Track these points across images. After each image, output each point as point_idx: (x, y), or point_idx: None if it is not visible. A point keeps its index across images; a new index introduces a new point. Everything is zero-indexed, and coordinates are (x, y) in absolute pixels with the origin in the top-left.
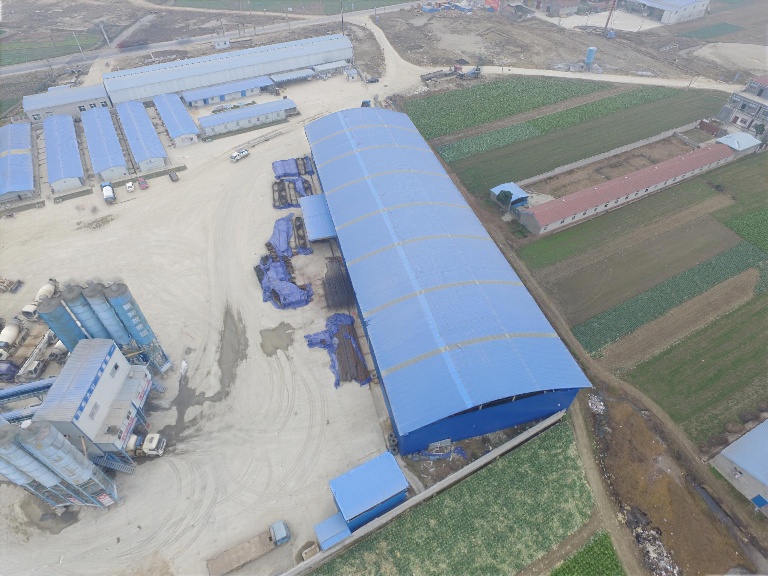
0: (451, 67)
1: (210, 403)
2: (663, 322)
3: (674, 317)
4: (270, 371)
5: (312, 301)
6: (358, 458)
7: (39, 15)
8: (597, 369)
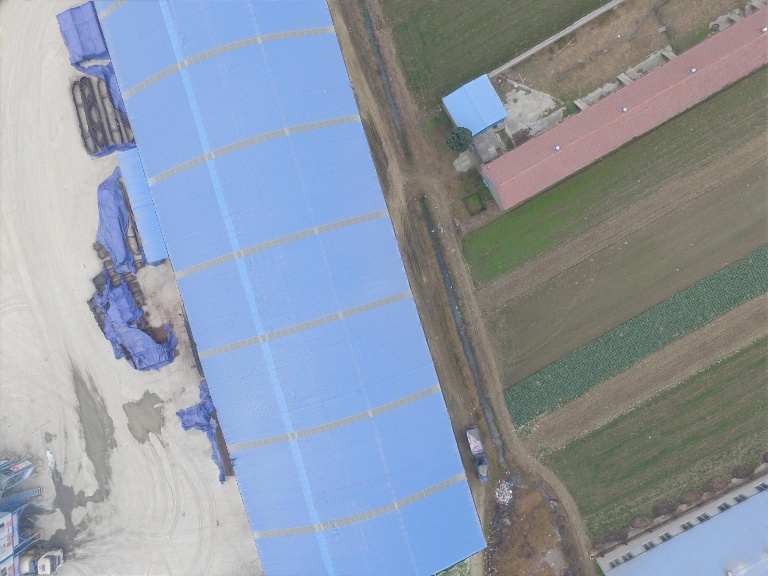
0: None
1: (93, 504)
2: (626, 379)
3: (644, 370)
4: (146, 463)
5: (177, 355)
6: (251, 560)
7: None
8: (518, 451)
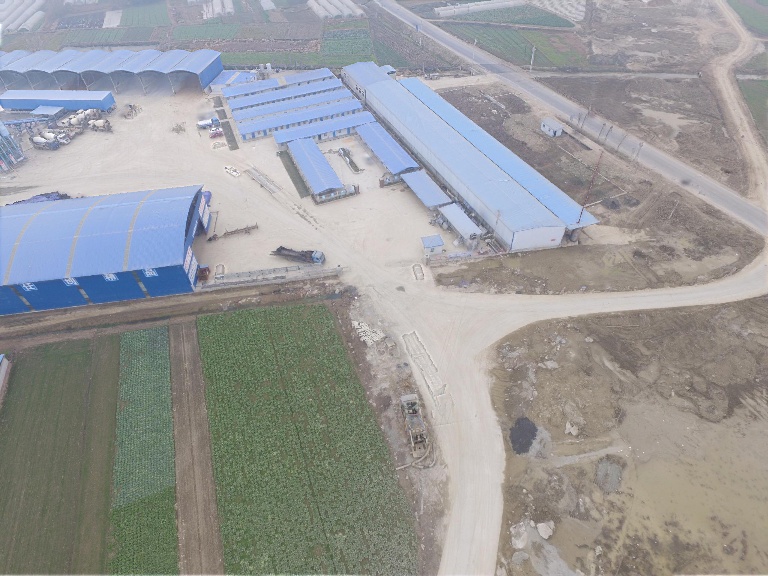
0: (490, 405)
1: None
2: None
3: None
4: None
5: None
6: None
7: (629, 26)
8: None
